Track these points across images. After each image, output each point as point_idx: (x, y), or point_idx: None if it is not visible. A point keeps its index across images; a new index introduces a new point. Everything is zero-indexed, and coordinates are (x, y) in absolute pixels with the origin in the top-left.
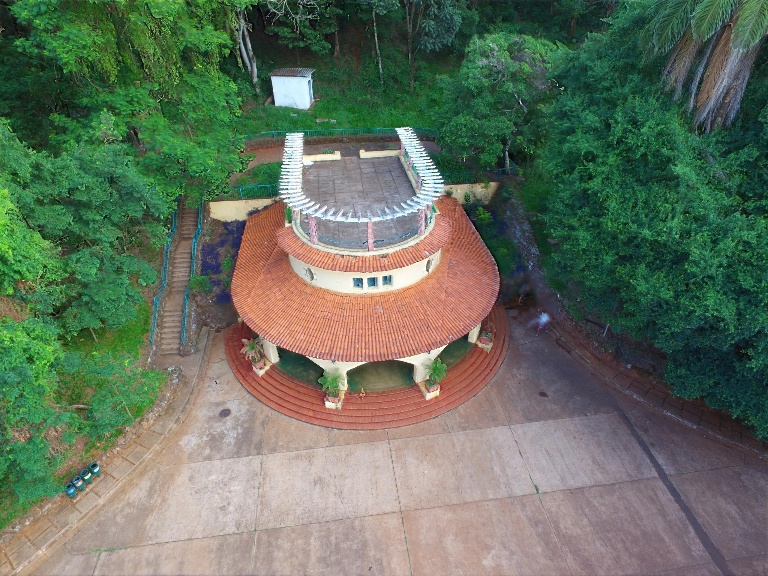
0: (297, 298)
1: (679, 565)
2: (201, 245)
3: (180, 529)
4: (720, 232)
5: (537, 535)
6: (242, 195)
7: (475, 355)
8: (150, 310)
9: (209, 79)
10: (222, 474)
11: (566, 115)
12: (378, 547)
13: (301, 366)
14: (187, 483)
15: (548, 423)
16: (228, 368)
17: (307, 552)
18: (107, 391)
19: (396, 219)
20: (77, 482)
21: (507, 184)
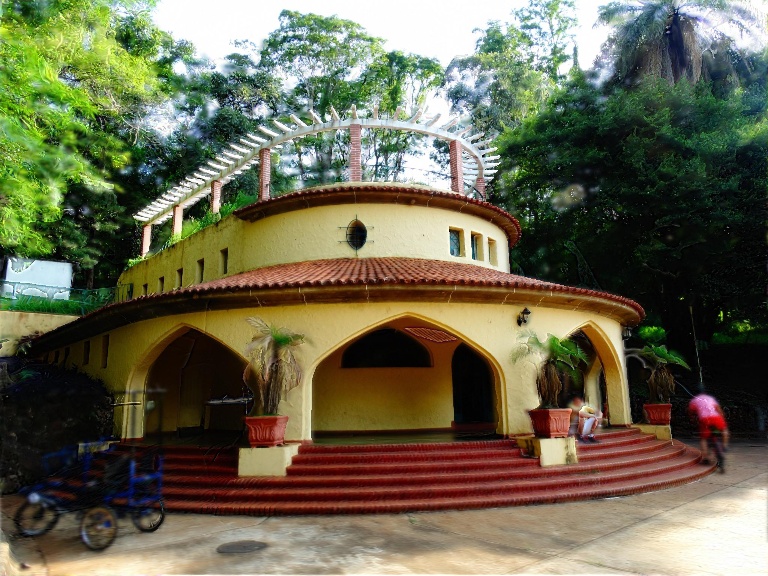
0: None
1: None
2: None
3: None
4: None
5: None
6: (9, 308)
7: None
8: None
9: None
10: None
11: None
12: None
13: None
14: None
15: None
16: (119, 510)
17: None
18: None
19: None
20: None
21: None
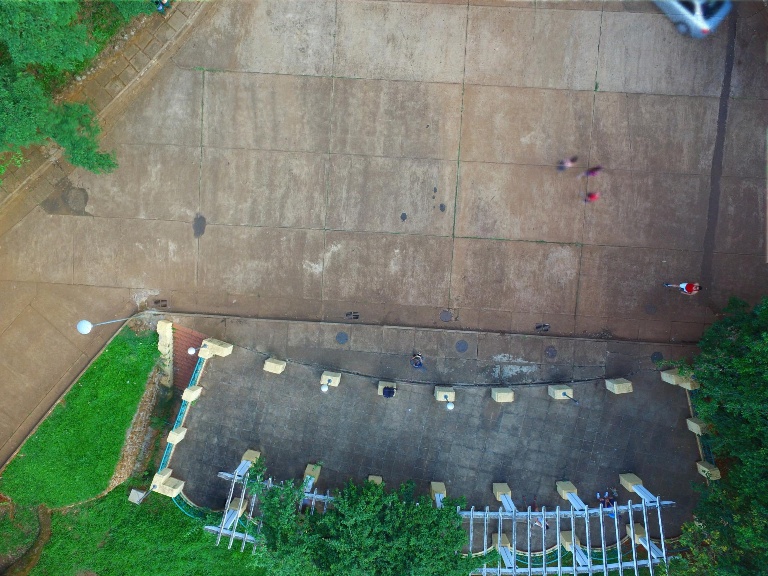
0: None
1: (680, 172)
2: None
3: (267, 63)
4: None
5: (576, 127)
6: None
7: None
8: None
9: None
10: (298, 13)
11: None
12: (437, 111)
13: None
14: (266, 17)
15: (646, 16)
16: None
17: (377, 104)
18: None
19: None
20: None
21: None
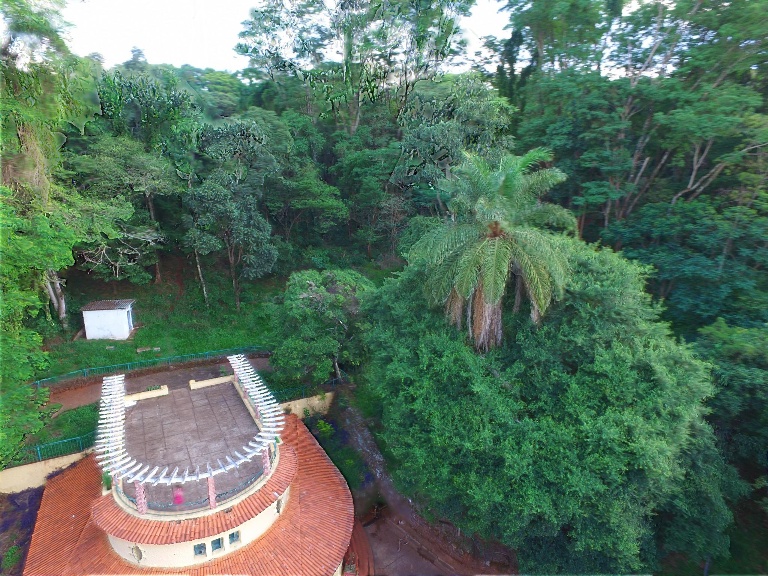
0: None
1: None
2: None
3: None
4: (520, 435)
5: None
6: (40, 455)
7: None
8: None
9: (7, 337)
10: None
11: (382, 344)
12: None
13: None
14: None
15: None
16: None
17: None
18: None
19: None
20: None
21: (342, 393)
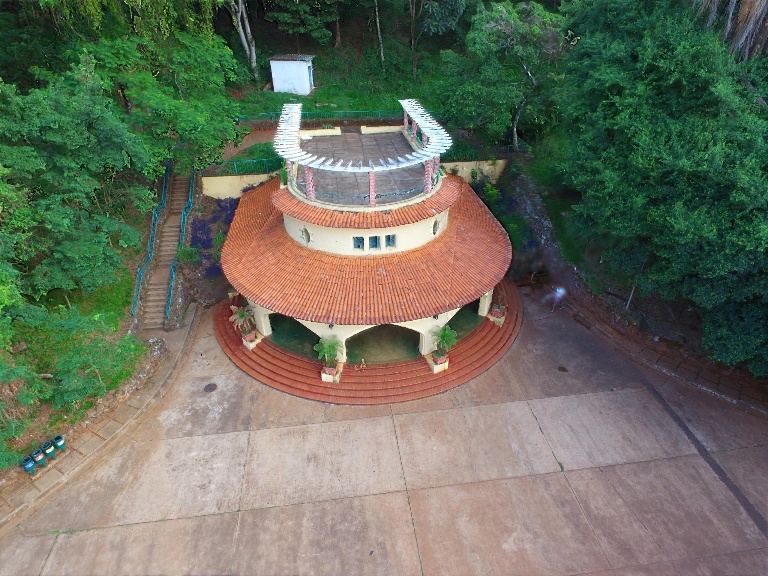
0: (292, 261)
1: (733, 549)
2: (191, 219)
3: (152, 509)
4: None
5: (564, 516)
6: (237, 171)
7: (486, 329)
8: (133, 282)
9: (202, 38)
10: (204, 450)
11: None
12: (381, 529)
13: (296, 339)
14: (164, 460)
15: (570, 398)
16: (216, 343)
17: (298, 534)
18: (75, 352)
19: (400, 182)
20: (37, 455)
21: (516, 161)
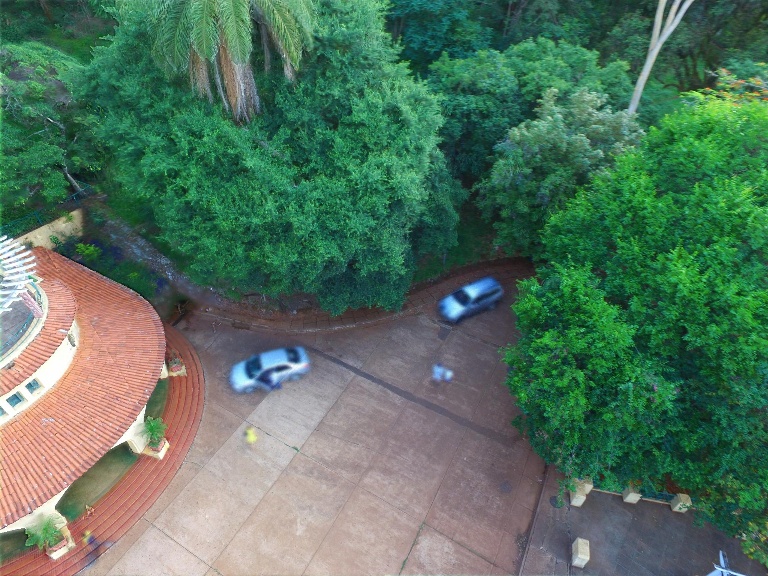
0: None
1: (396, 418)
2: None
3: None
4: (300, 198)
5: (317, 479)
6: None
7: (176, 386)
8: None
9: None
10: None
11: (123, 136)
12: None
13: None
14: None
15: (271, 395)
16: None
17: None
18: None
19: None
20: None
21: (91, 208)
